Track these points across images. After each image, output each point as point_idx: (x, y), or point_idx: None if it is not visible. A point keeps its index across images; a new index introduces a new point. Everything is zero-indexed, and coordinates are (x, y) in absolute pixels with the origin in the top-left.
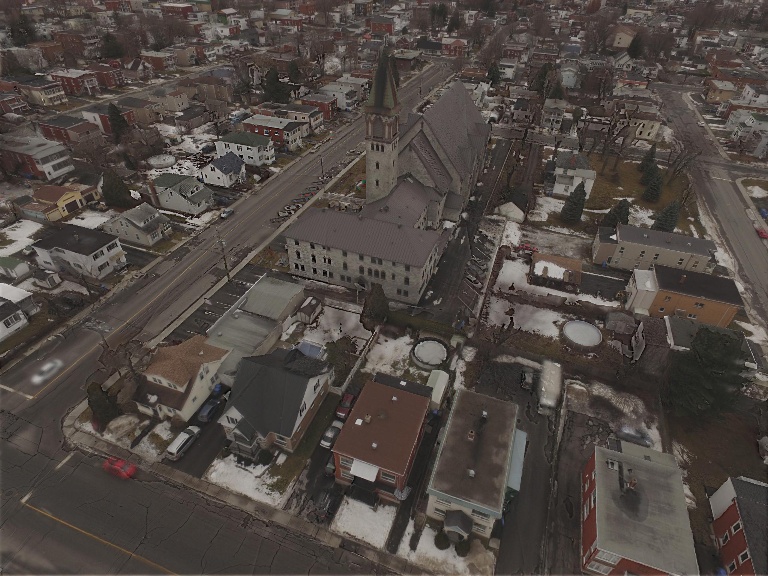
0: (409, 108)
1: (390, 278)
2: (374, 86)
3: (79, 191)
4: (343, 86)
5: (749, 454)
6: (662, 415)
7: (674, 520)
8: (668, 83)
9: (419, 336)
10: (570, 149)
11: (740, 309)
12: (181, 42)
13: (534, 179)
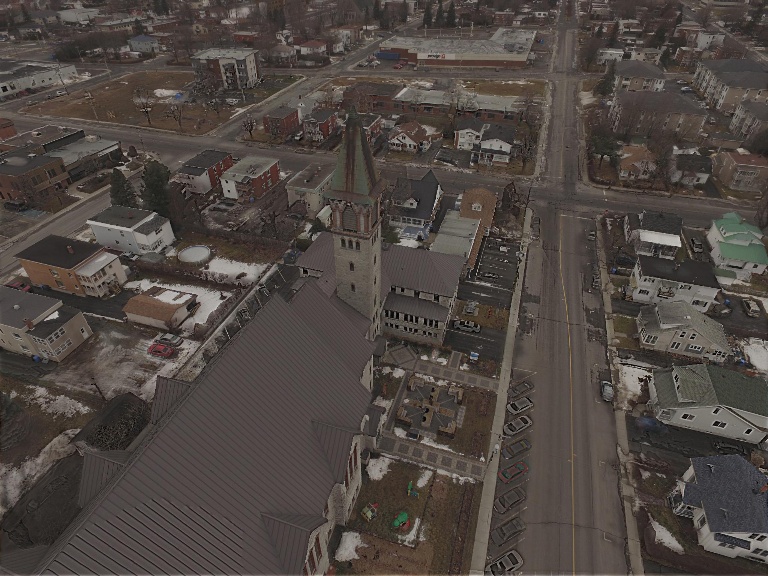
0: None
1: None
2: None
3: None
4: None
5: None
6: None
7: None
8: None
9: None
10: None
11: None
12: None
13: None
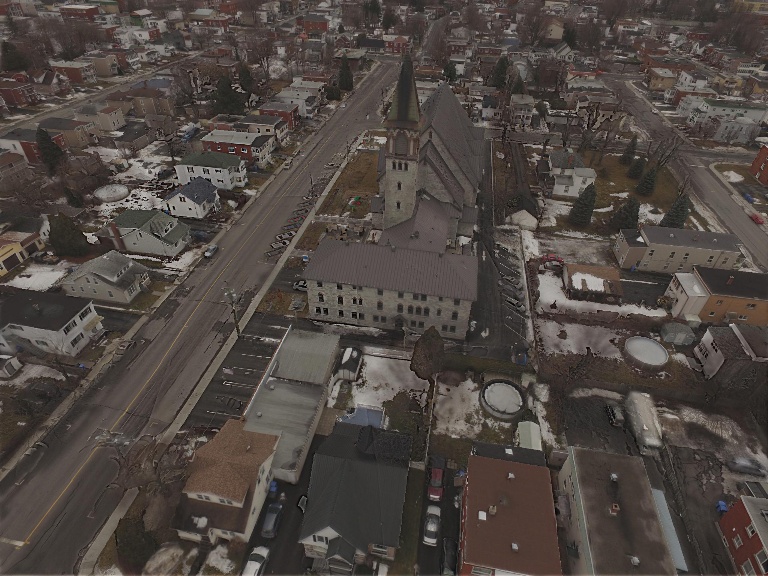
0: (372, 111)
1: (435, 314)
2: (397, 97)
3: (18, 242)
4: (300, 92)
5: None
6: (763, 436)
7: None
8: (608, 72)
9: (485, 380)
10: (549, 145)
11: None
12: (94, 49)
13: (528, 181)
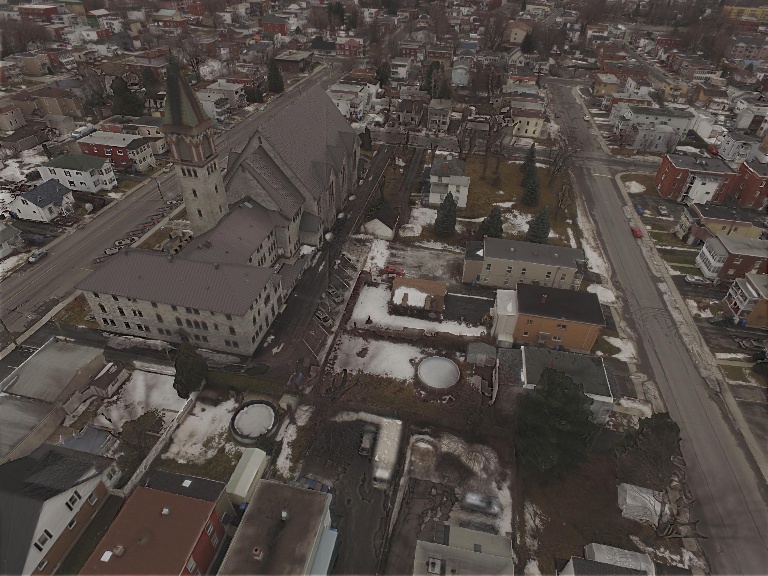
0: None
1: (213, 329)
2: (168, 100)
3: None
4: (212, 93)
5: (606, 506)
6: (515, 470)
7: None
8: (559, 77)
9: (242, 400)
10: (454, 152)
11: (610, 322)
12: (37, 48)
13: (412, 188)
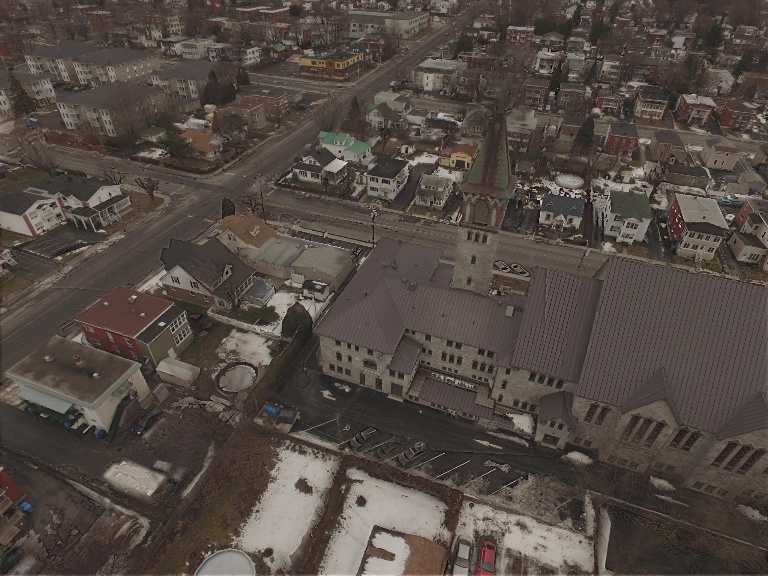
0: None
1: None
2: None
3: (471, 157)
4: None
5: None
6: None
7: None
8: None
9: None
10: None
11: None
12: None
13: None
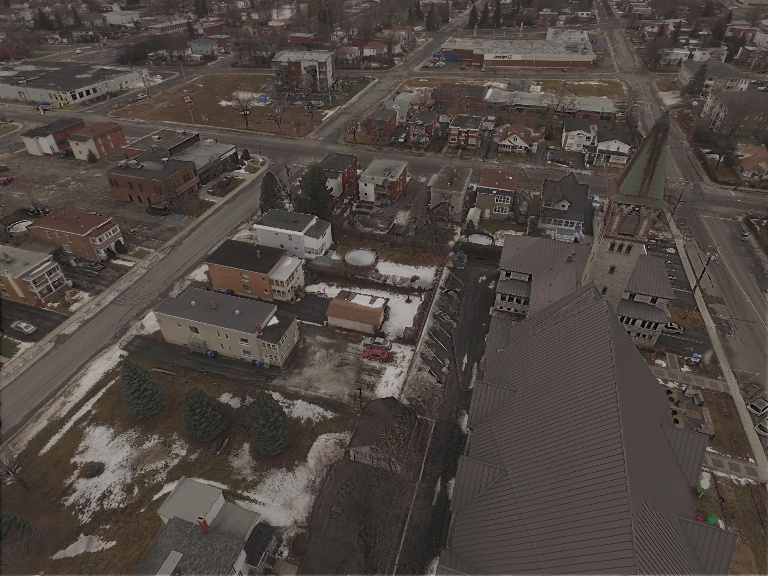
0: None
1: None
2: None
3: None
4: None
5: None
6: None
7: (375, 166)
8: None
9: None
10: None
11: None
12: None
13: None
